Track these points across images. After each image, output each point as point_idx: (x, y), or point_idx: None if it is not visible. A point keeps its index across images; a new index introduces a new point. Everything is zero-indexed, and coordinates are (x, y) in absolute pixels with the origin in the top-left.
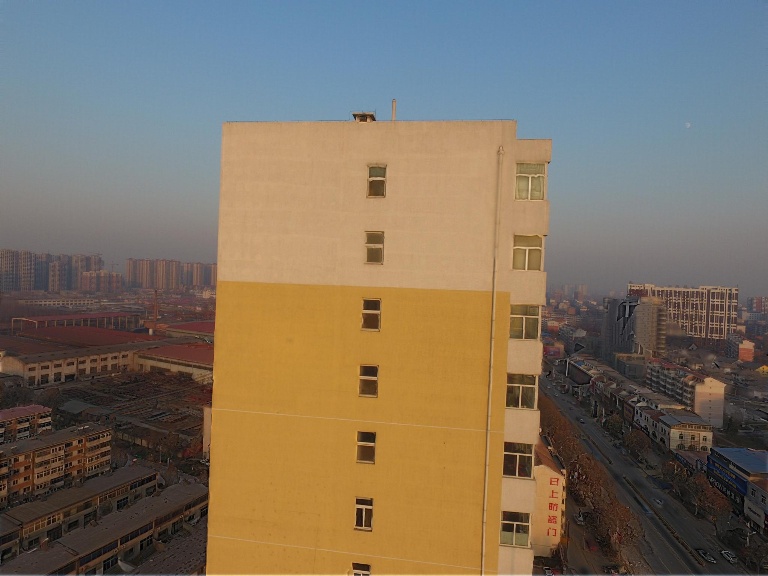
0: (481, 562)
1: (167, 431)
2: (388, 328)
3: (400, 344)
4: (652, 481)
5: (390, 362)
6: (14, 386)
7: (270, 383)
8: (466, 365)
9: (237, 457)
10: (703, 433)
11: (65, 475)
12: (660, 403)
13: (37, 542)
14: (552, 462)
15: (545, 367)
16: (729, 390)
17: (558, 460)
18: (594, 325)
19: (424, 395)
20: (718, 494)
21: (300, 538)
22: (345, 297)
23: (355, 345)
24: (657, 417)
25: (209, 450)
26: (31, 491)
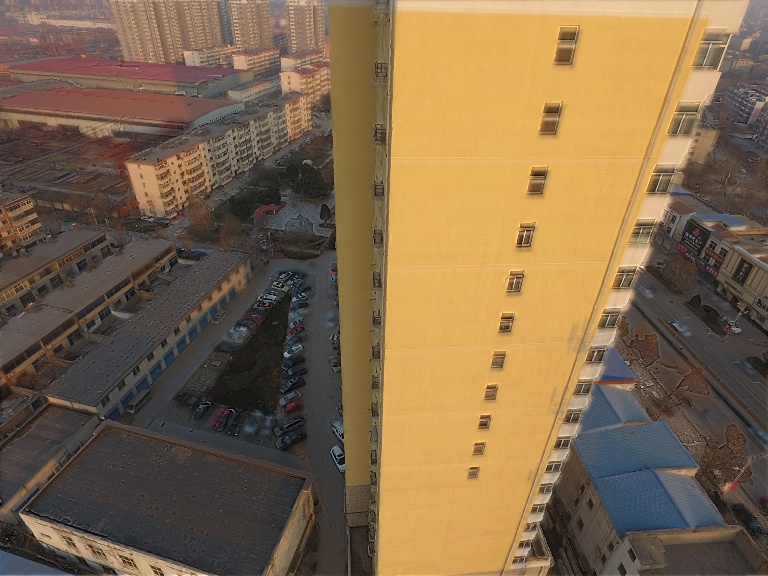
0: (611, 257)
1: (85, 192)
2: (581, 60)
3: (589, 77)
4: None
5: (575, 97)
6: None
7: (453, 127)
8: (645, 96)
9: (416, 200)
10: None
11: None
12: None
13: (14, 308)
14: None
15: None
16: None
17: None
18: None
19: (600, 128)
20: None
21: (469, 259)
22: (543, 25)
23: (544, 81)
24: None
25: (150, 207)
26: None
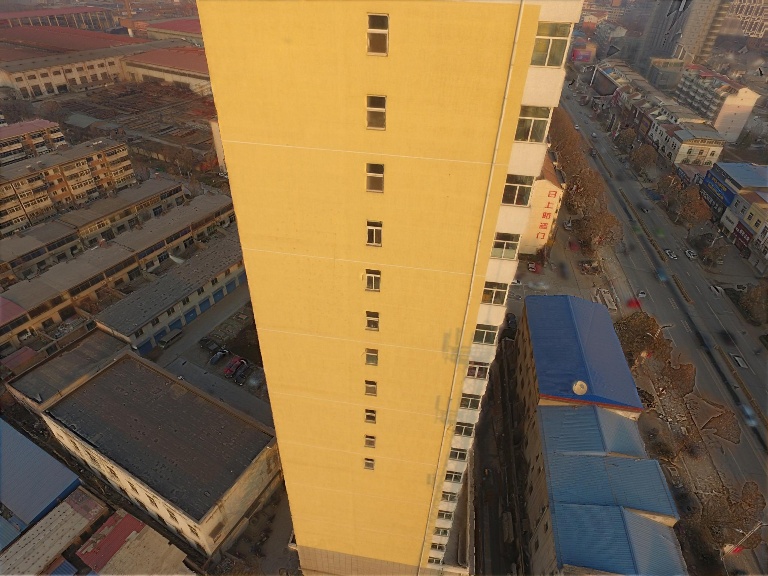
0: (473, 270)
1: (180, 145)
2: (397, 52)
3: (410, 71)
4: (645, 193)
5: (399, 92)
6: (9, 98)
7: (275, 115)
8: (479, 96)
9: (255, 186)
10: (713, 148)
11: (97, 187)
12: (681, 117)
13: (96, 241)
14: (554, 177)
15: (569, 75)
16: (761, 102)
17: (560, 175)
18: (638, 21)
19: (433, 128)
20: (703, 205)
21: (320, 251)
22: (347, 12)
23: (361, 72)
24: (673, 131)
25: None
26: (72, 200)
